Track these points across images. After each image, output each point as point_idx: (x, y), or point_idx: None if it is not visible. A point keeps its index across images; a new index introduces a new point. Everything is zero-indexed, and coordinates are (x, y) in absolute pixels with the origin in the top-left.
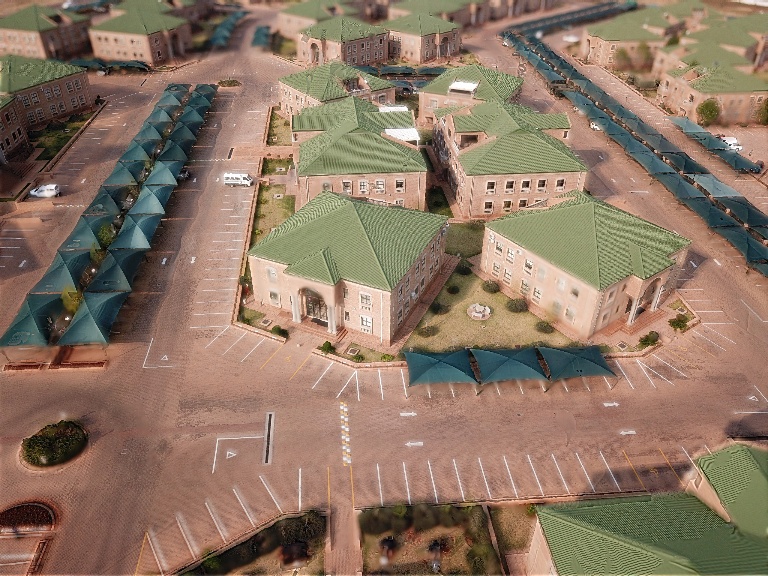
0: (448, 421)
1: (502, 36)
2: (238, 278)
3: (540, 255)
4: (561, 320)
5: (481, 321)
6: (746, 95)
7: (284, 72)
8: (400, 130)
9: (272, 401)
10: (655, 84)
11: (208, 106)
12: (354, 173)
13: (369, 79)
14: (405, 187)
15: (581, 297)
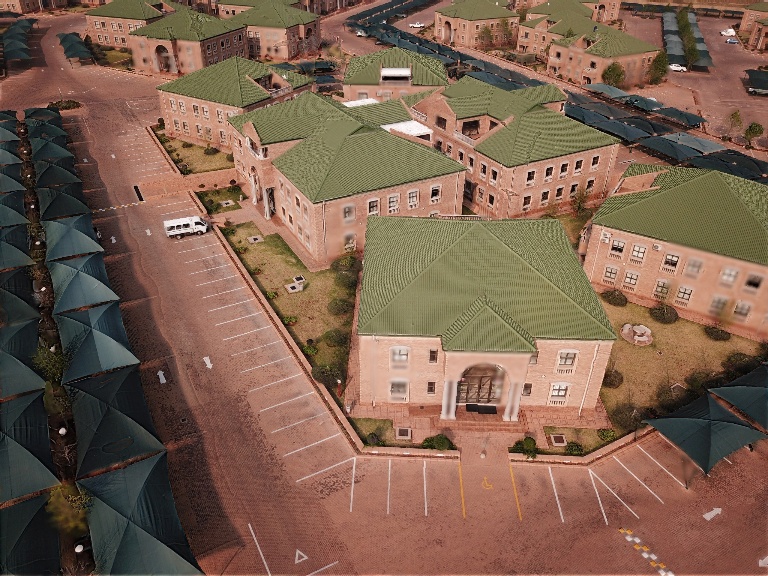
0: (763, 504)
1: (351, 27)
2: (304, 373)
3: (695, 245)
4: (726, 320)
5: (650, 346)
6: (639, 57)
7: (130, 85)
8: (399, 124)
9: (532, 569)
10: (535, 59)
11: (64, 135)
12: (383, 187)
13: (284, 74)
14: (441, 195)
15: (766, 286)
